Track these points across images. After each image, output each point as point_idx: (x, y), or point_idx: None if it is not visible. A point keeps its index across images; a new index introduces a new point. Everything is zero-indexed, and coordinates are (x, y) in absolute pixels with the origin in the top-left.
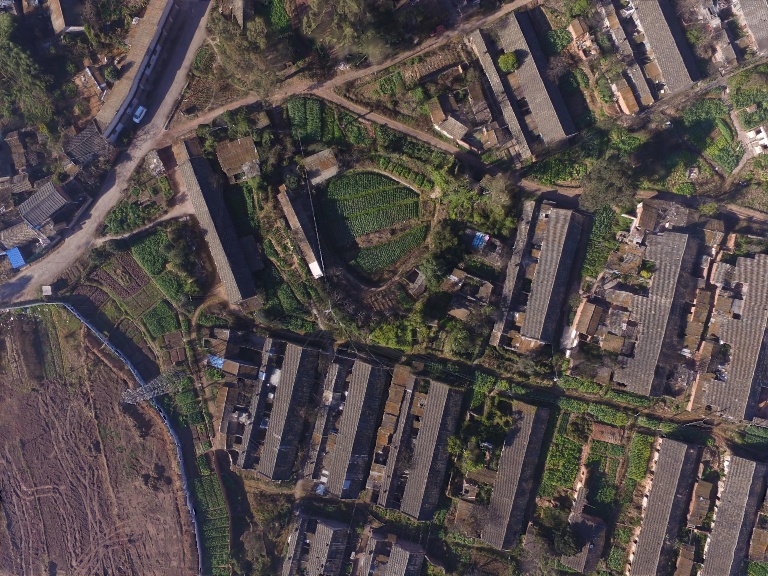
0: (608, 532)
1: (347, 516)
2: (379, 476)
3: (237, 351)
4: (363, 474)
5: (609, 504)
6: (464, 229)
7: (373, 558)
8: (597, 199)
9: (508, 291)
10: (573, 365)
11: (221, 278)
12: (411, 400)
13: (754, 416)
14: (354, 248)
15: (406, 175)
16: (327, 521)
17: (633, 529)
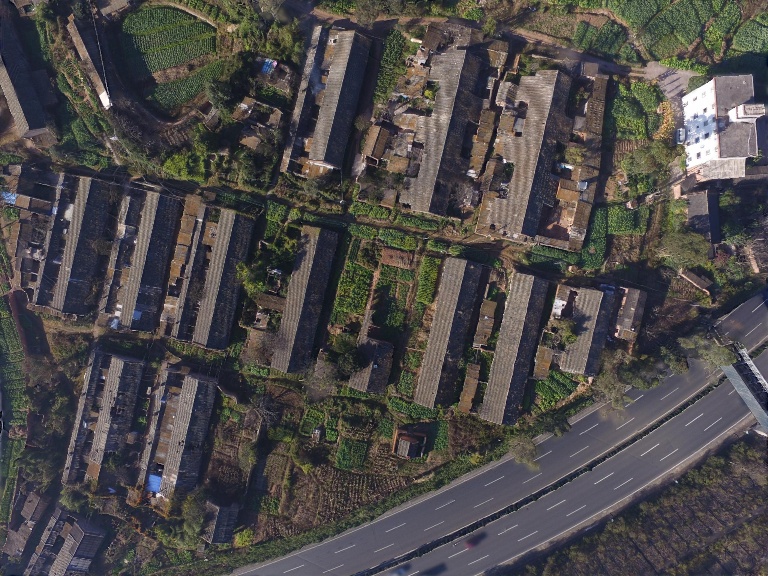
0: (398, 356)
1: (144, 352)
2: (172, 308)
3: (31, 187)
4: (157, 307)
5: (398, 328)
6: (255, 58)
7: (165, 390)
8: (368, 9)
9: (296, 117)
10: (361, 189)
11: (11, 111)
12: (202, 230)
13: (538, 234)
14: (152, 84)
15: (201, 8)
16: (122, 356)
17: (423, 353)
